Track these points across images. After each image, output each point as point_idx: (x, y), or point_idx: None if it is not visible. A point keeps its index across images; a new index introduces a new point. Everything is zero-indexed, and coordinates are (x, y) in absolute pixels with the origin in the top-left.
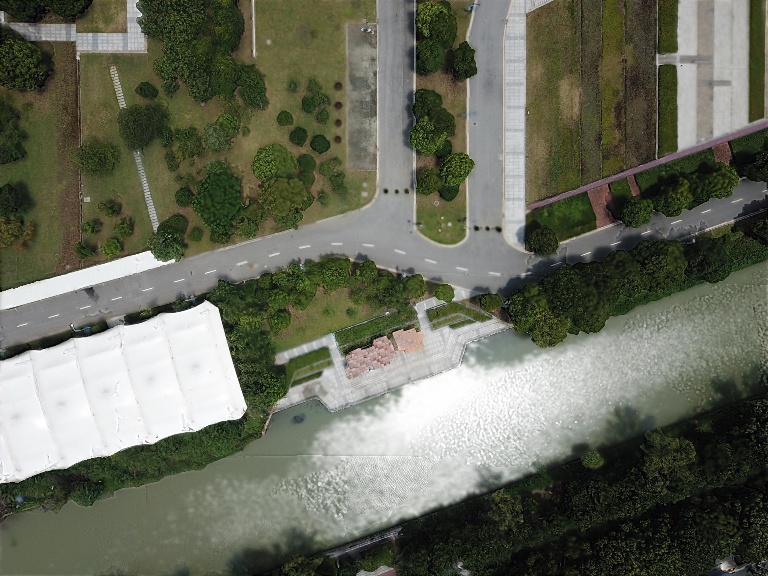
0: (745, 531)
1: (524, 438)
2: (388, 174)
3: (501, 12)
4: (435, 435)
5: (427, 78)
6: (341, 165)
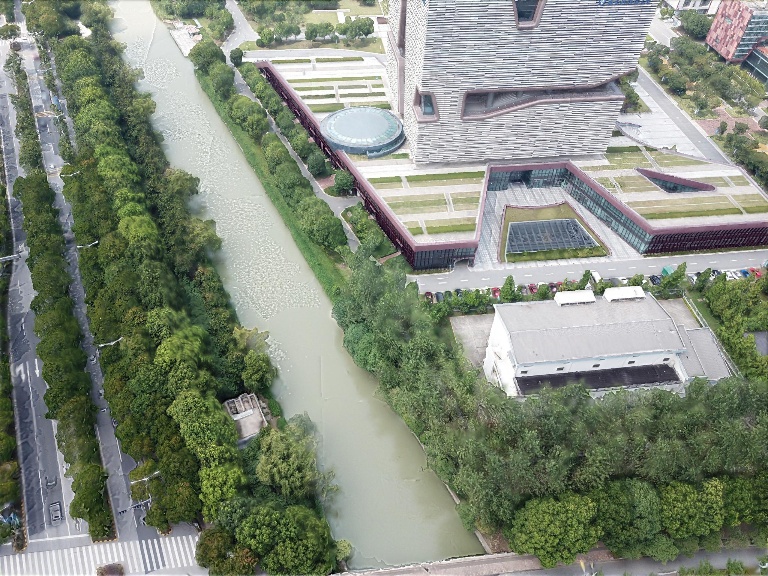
0: None
1: None
2: None
3: None
4: None
5: None
6: None
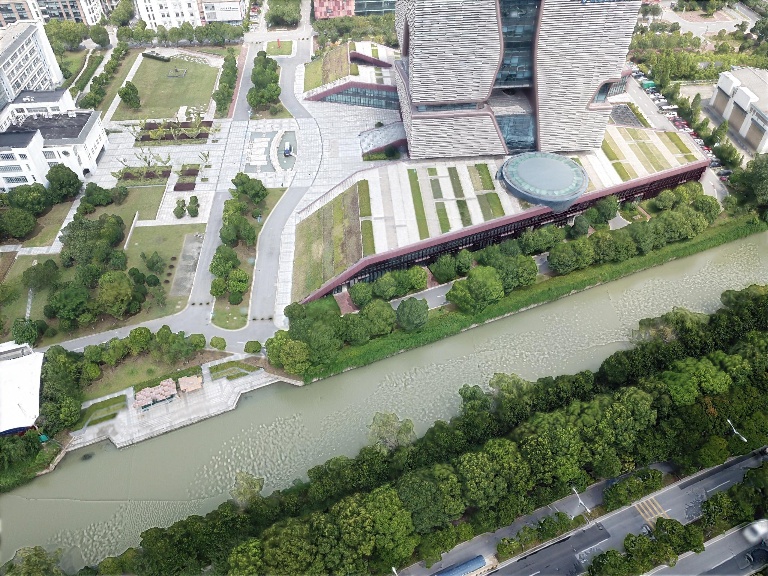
0: (460, 475)
1: (292, 473)
2: (197, 297)
3: (281, 225)
4: (211, 477)
5: None
6: (166, 294)
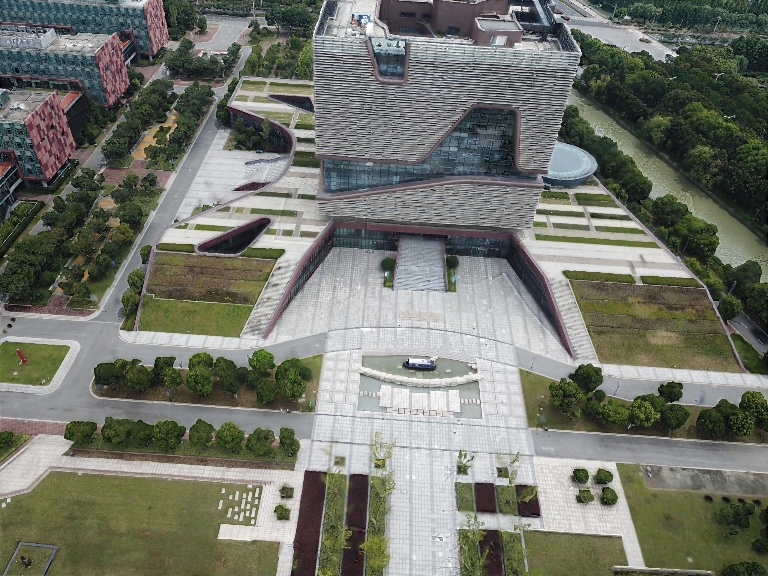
0: None
1: None
2: (766, 465)
3: (603, 378)
4: None
5: (674, 430)
6: None
